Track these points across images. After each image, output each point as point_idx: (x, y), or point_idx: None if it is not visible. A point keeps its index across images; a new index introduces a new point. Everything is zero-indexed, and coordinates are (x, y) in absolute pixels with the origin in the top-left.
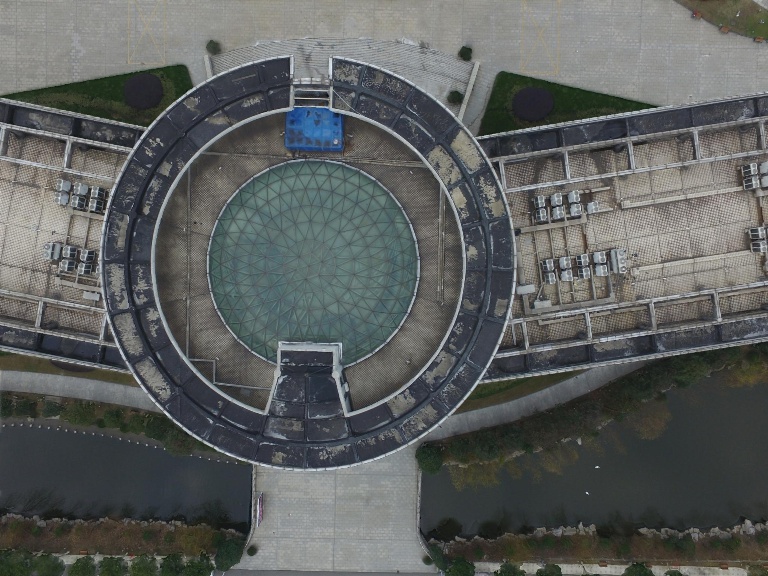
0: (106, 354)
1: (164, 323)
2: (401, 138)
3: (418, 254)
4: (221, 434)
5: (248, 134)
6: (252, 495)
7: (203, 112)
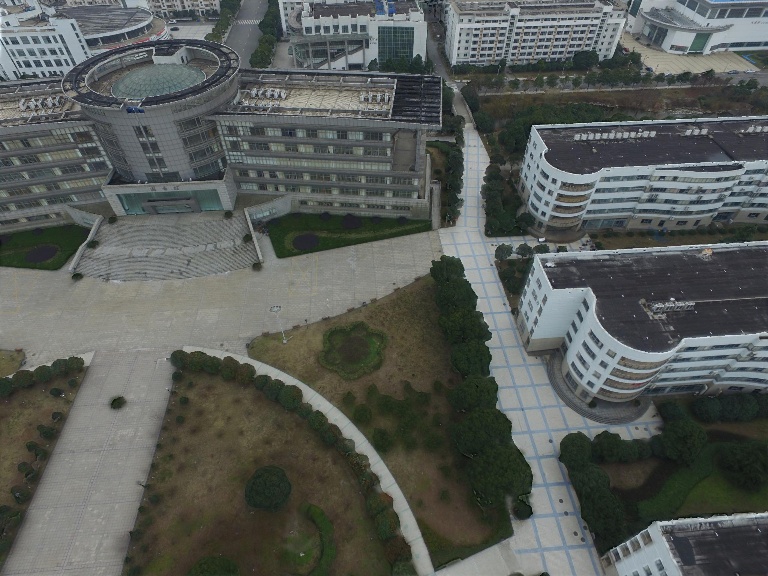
0: None
1: None
2: None
3: None
4: None
5: None
6: None
7: None
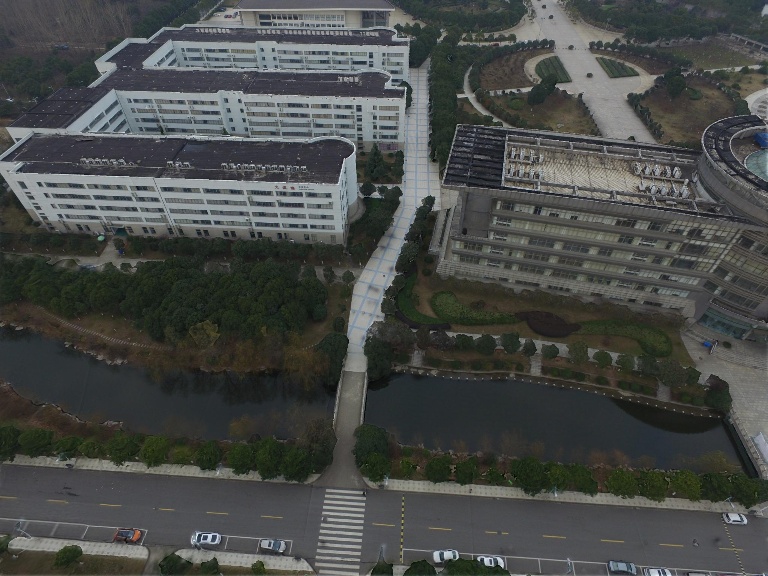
0: None
1: (761, 178)
2: None
3: None
4: None
5: (735, 145)
6: (747, 436)
7: None
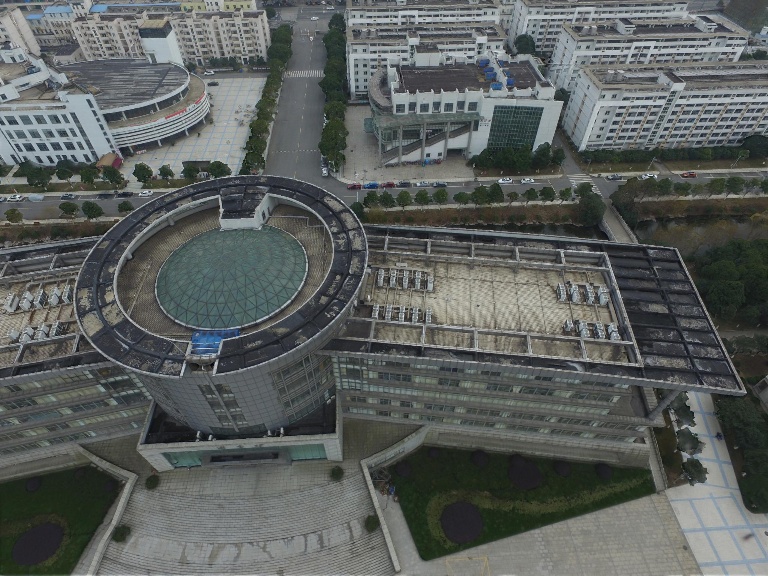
0: (385, 234)
1: (326, 225)
2: (140, 327)
3: (156, 281)
4: (295, 186)
5: None
6: None
7: (293, 335)
